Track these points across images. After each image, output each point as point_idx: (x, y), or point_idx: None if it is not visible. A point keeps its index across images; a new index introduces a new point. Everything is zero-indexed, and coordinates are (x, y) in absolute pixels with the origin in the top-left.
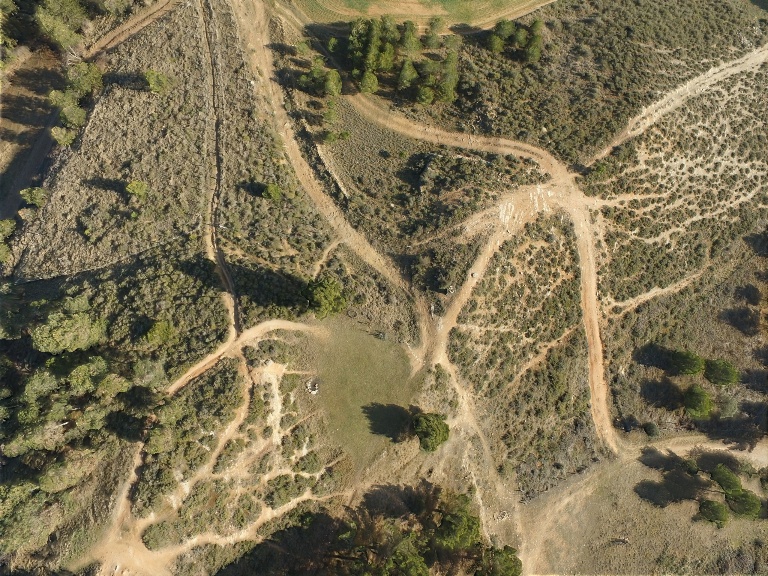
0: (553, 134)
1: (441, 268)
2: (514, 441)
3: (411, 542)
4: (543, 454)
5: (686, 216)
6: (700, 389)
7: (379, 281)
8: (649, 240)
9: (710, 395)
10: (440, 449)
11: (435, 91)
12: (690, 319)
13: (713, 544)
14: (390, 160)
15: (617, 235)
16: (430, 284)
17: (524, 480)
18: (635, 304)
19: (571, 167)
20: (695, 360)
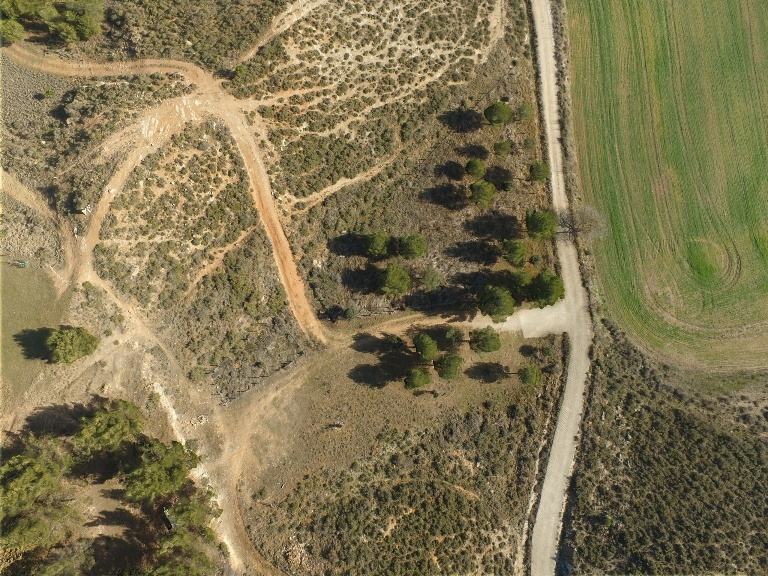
0: (196, 45)
1: (79, 190)
2: (198, 347)
3: (70, 453)
4: (240, 356)
5: (364, 104)
6: (391, 267)
7: (30, 216)
8: (325, 133)
9: (422, 274)
10: (112, 365)
11: (74, 25)
12: (390, 204)
13: (438, 415)
14: (44, 101)
15: (282, 133)
16: (71, 208)
17: (222, 383)
18: (321, 198)
19: (216, 74)
20: (374, 238)
